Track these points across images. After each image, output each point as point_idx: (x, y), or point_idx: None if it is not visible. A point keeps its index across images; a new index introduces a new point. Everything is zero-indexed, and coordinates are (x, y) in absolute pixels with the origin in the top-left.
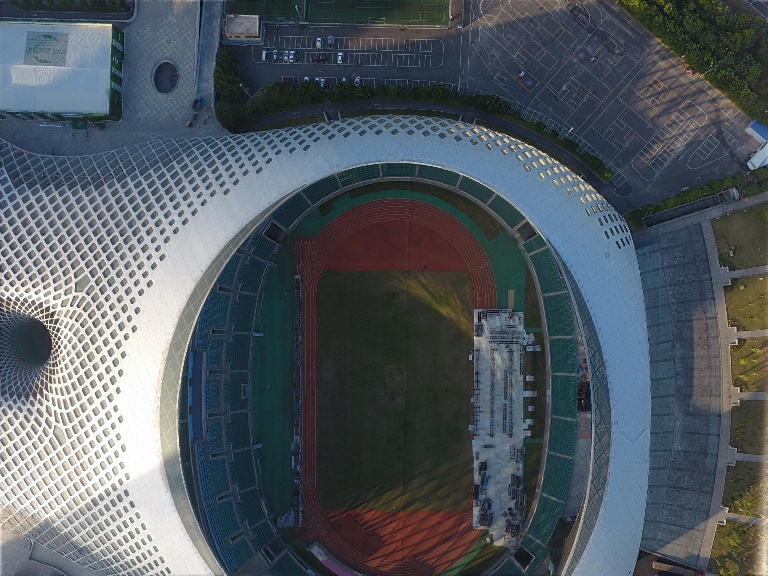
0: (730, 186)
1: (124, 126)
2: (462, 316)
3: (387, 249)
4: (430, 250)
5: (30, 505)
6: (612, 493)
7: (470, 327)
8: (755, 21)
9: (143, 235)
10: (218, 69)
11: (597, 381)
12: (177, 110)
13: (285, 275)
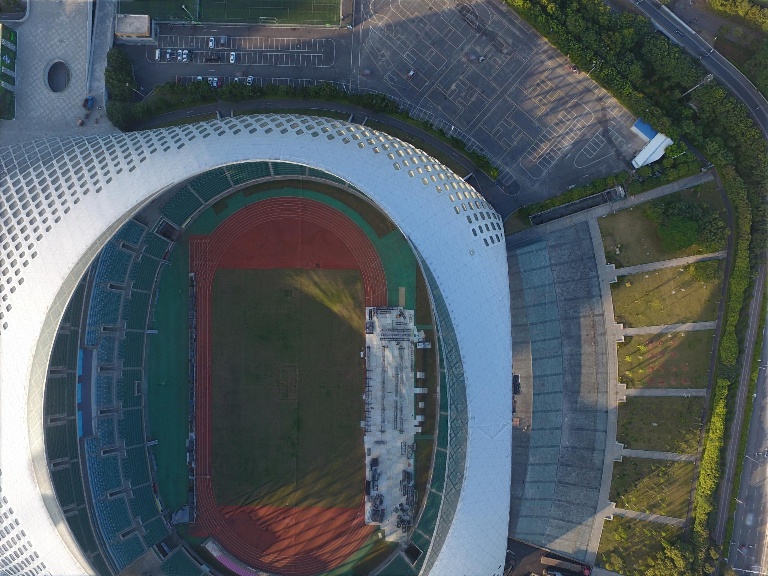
0: (616, 184)
1: (17, 125)
2: (354, 313)
3: (280, 247)
4: (322, 248)
5: None
6: (470, 488)
7: (362, 324)
8: (636, 21)
9: (18, 233)
10: (108, 68)
11: (453, 377)
12: (69, 109)
13: (179, 273)
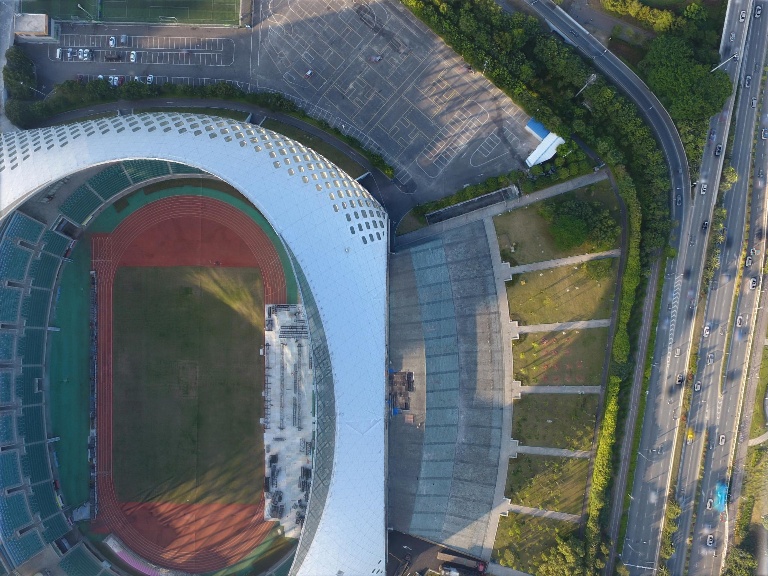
0: (511, 183)
1: None
2: (253, 311)
3: (180, 245)
4: (222, 246)
5: None
6: (340, 483)
7: (261, 322)
8: (527, 21)
9: None
10: (6, 67)
11: (321, 373)
12: None
13: (81, 271)
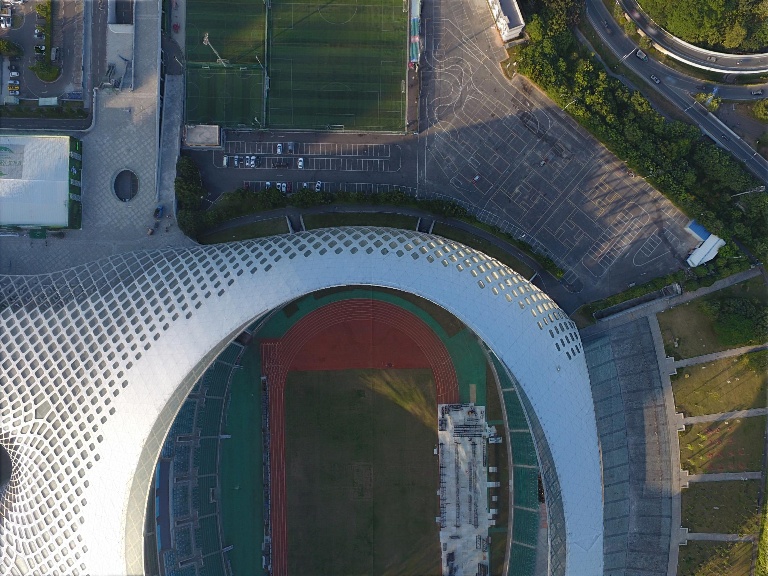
0: (673, 281)
1: (84, 235)
2: (426, 411)
3: (352, 348)
4: (393, 348)
5: None
6: None
7: (434, 422)
8: (689, 130)
9: (105, 360)
10: (179, 179)
11: (551, 496)
12: (138, 218)
13: (251, 376)
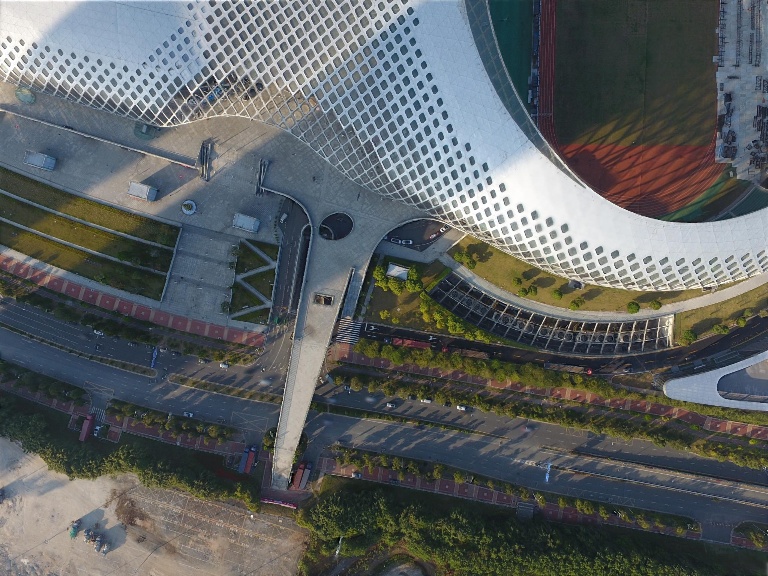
0: None
1: None
2: None
3: None
4: None
5: (296, 80)
6: None
7: None
8: None
9: None
10: None
11: None
12: None
13: None
